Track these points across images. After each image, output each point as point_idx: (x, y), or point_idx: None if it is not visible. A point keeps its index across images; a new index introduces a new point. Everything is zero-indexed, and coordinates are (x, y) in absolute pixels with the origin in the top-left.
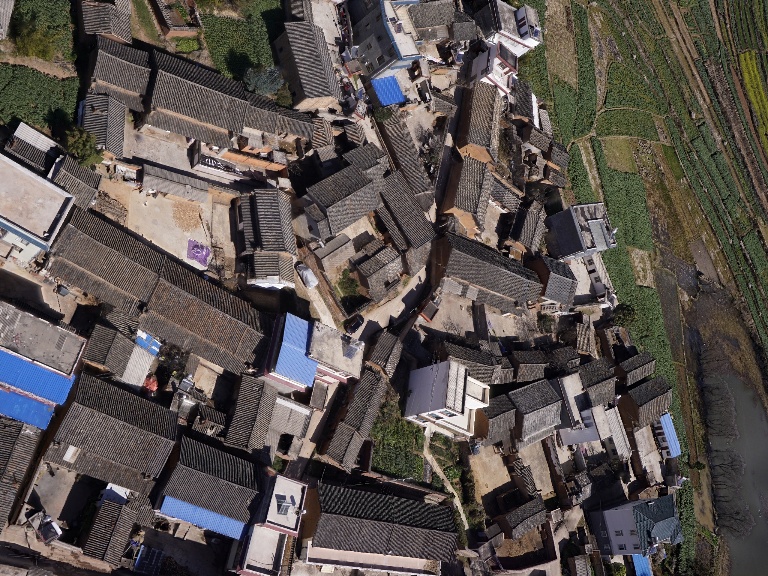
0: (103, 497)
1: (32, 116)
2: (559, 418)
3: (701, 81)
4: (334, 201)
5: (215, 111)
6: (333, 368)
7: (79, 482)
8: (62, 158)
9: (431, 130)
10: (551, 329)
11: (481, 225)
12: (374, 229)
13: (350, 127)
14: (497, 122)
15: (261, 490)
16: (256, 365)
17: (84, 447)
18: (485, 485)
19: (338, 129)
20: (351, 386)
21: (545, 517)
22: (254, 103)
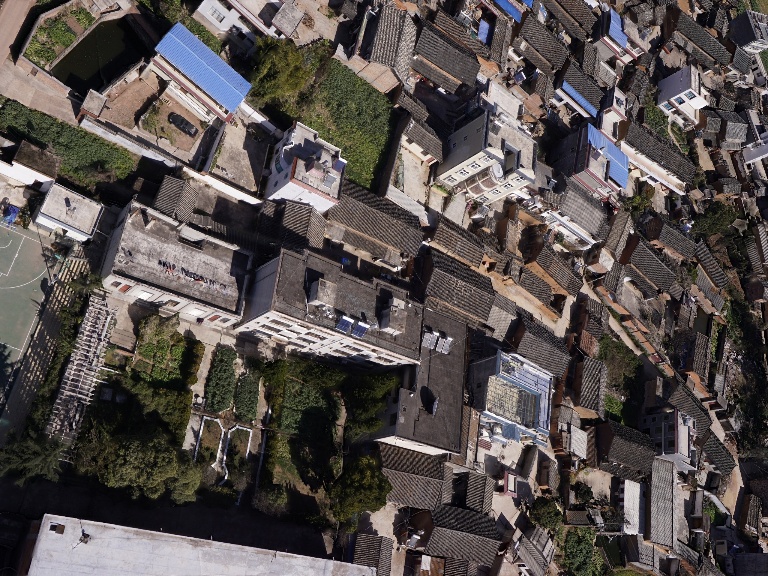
0: (534, 75)
1: None
2: (745, 137)
3: None
4: None
5: None
6: (632, 47)
7: None
8: None
9: None
10: (734, 90)
11: None
12: None
13: None
14: None
15: (605, 94)
16: (593, 36)
17: (531, 41)
18: (701, 166)
19: None
20: (627, 80)
21: None
22: None
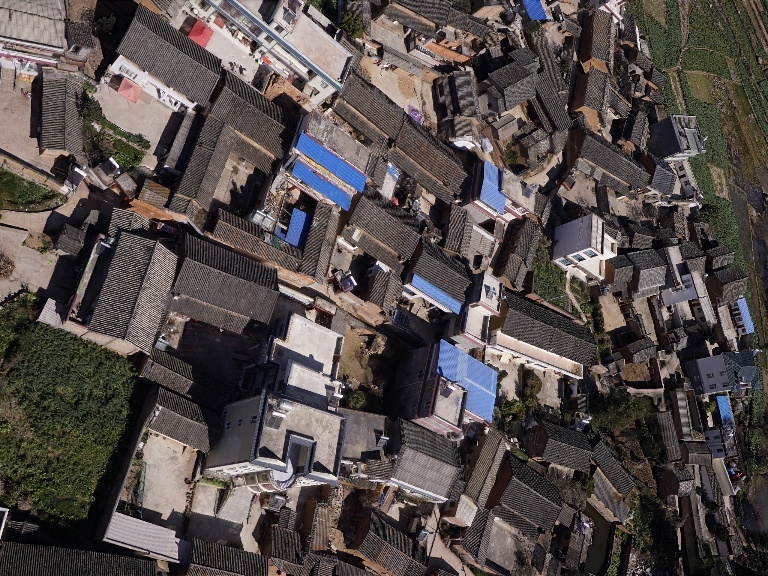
0: (374, 270)
1: (313, 2)
2: (664, 280)
3: (766, 32)
4: (509, 84)
5: (430, 8)
6: (514, 205)
7: (355, 261)
8: (340, 31)
9: (561, 46)
10: (654, 214)
11: (604, 122)
12: (526, 117)
13: (511, 34)
14: (612, 43)
15: (472, 282)
16: (462, 197)
17: (367, 230)
18: (608, 324)
19: (502, 35)
20: (514, 232)
21: (655, 352)
22: (452, 6)
